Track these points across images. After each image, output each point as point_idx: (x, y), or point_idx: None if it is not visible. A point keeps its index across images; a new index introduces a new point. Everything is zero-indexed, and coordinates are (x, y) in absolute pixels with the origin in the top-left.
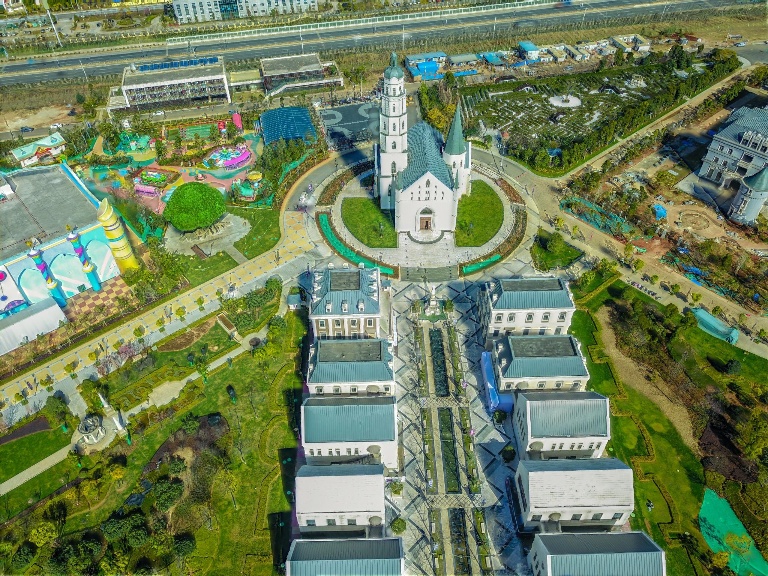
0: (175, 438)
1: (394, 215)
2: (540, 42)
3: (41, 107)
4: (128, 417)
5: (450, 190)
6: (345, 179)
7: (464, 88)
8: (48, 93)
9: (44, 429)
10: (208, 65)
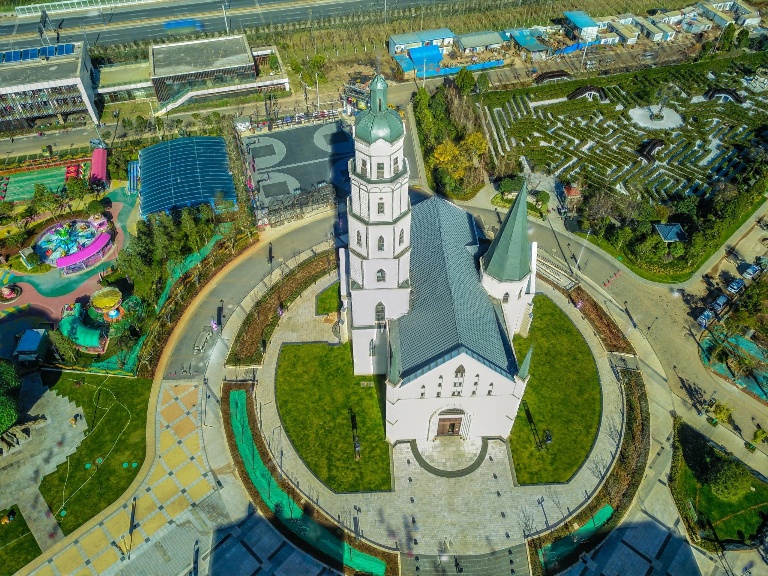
0: None
1: (382, 393)
2: (592, 11)
3: None
4: None
5: (508, 380)
6: (286, 295)
7: (488, 94)
8: None
9: None
10: (54, 59)
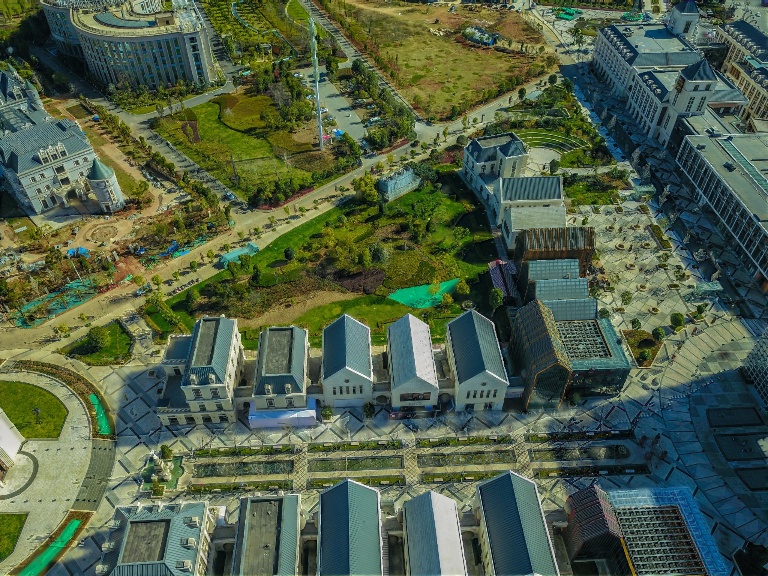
0: None
1: None
2: None
3: None
4: None
5: None
6: None
7: None
8: None
9: None
10: None
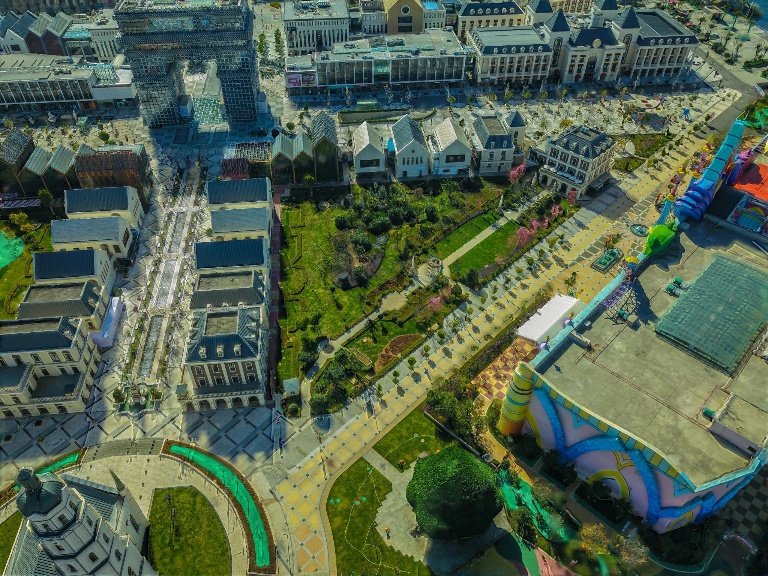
0: None
1: None
2: None
3: None
4: None
5: None
6: None
7: None
8: None
9: None
10: None
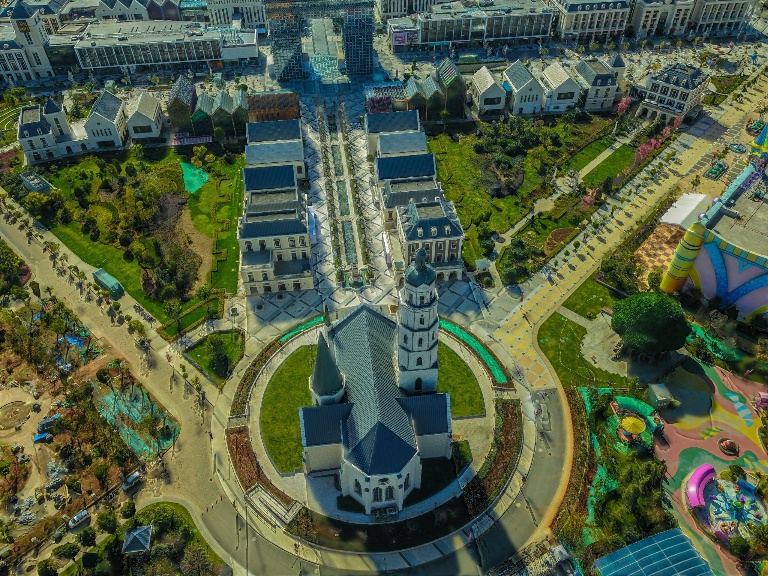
0: (516, 180)
1: None
2: None
3: None
4: None
5: None
6: (498, 457)
7: None
8: None
9: None
10: None
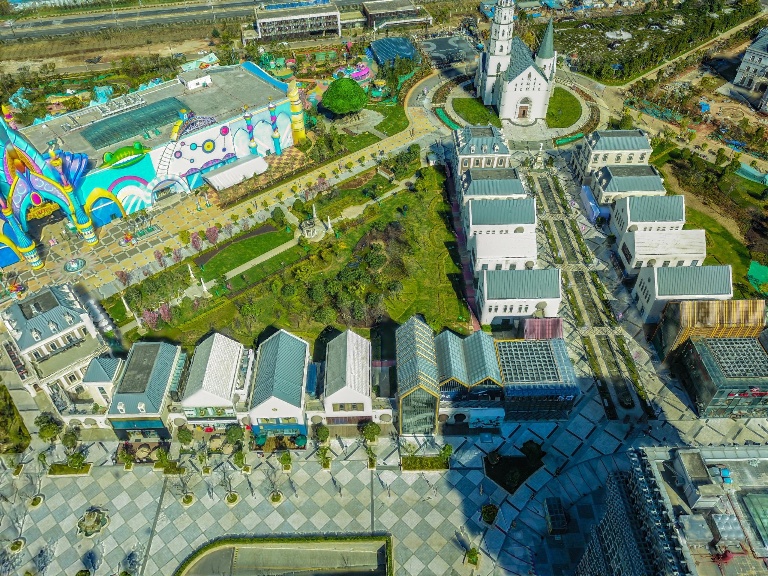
0: (370, 233)
1: (495, 109)
2: None
3: (184, 40)
4: (332, 223)
5: (546, 82)
6: (450, 86)
7: (533, 25)
8: (186, 30)
9: (272, 231)
10: (322, 5)
